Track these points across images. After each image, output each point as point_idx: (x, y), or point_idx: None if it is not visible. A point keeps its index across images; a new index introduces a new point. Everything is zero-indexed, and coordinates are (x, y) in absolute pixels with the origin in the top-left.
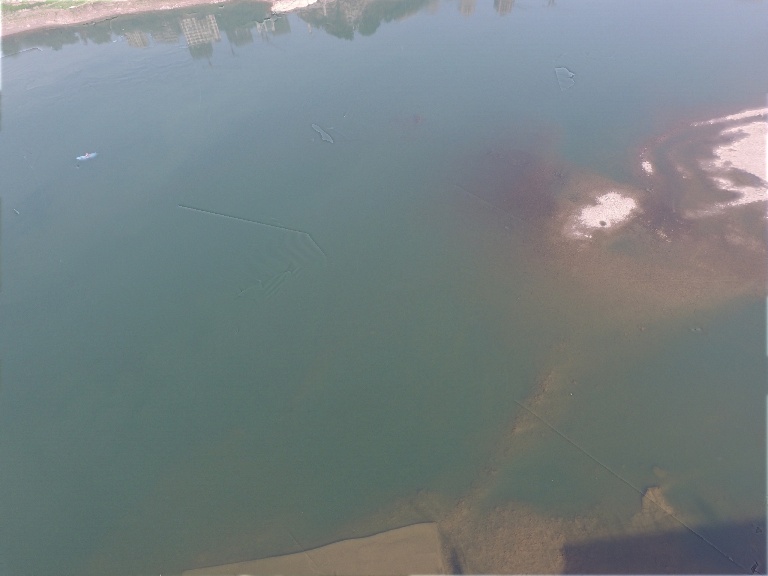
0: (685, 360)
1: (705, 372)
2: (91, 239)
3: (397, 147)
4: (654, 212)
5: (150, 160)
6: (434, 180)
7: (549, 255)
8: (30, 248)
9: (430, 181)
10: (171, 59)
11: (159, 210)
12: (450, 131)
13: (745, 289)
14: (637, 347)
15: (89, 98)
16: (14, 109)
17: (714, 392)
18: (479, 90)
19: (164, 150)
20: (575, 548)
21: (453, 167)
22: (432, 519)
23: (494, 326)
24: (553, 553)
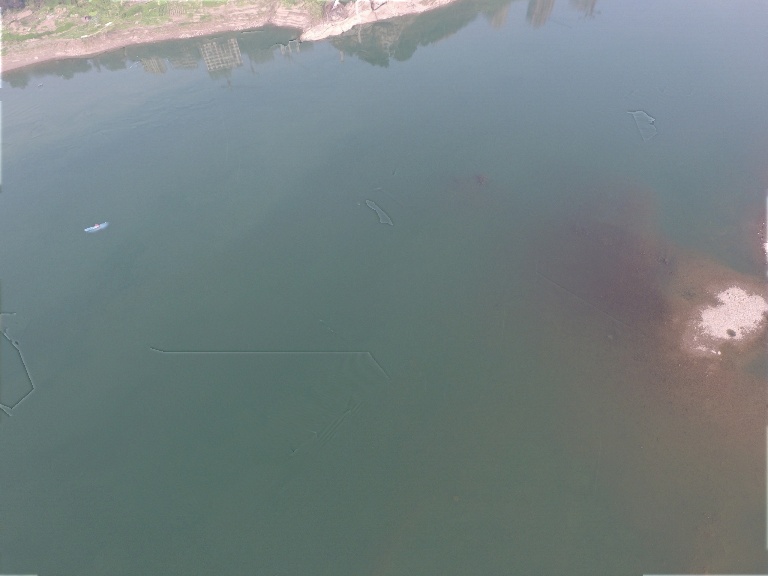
0: None
1: None
2: (100, 419)
3: (460, 217)
4: None
5: (171, 237)
6: (507, 261)
7: (671, 380)
8: None
9: (502, 262)
10: (193, 98)
11: (190, 364)
12: (523, 198)
13: None
14: None
15: (101, 149)
16: (17, 162)
17: None
18: (549, 142)
19: (188, 223)
20: None
21: (531, 246)
22: None
23: (616, 491)
24: None
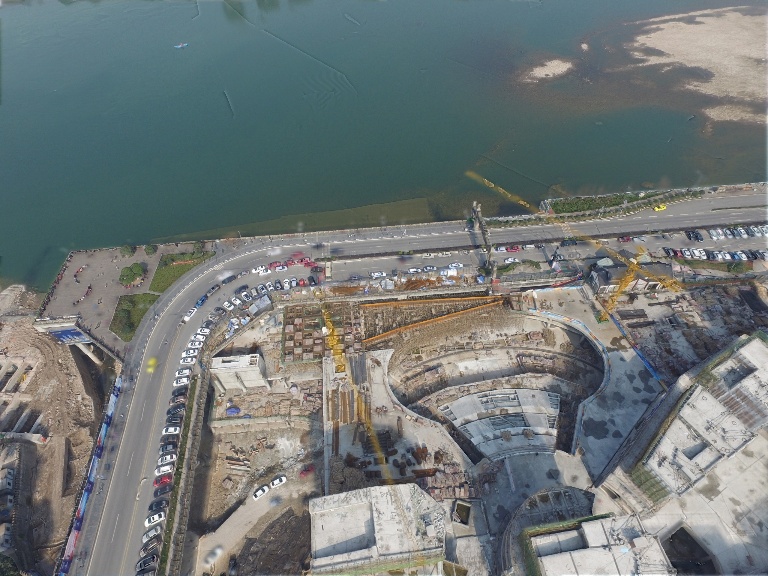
0: (589, 137)
1: (601, 143)
2: (222, 41)
3: (405, 40)
4: (584, 69)
5: None
6: (431, 59)
7: (508, 91)
8: (155, 91)
9: (428, 60)
10: None
11: (258, 33)
12: (444, 28)
13: (636, 105)
14: (559, 131)
15: (174, 15)
16: (119, 23)
17: (605, 152)
18: (467, 6)
19: None
20: (506, 206)
21: (445, 49)
22: (424, 197)
23: (467, 123)
24: (493, 207)
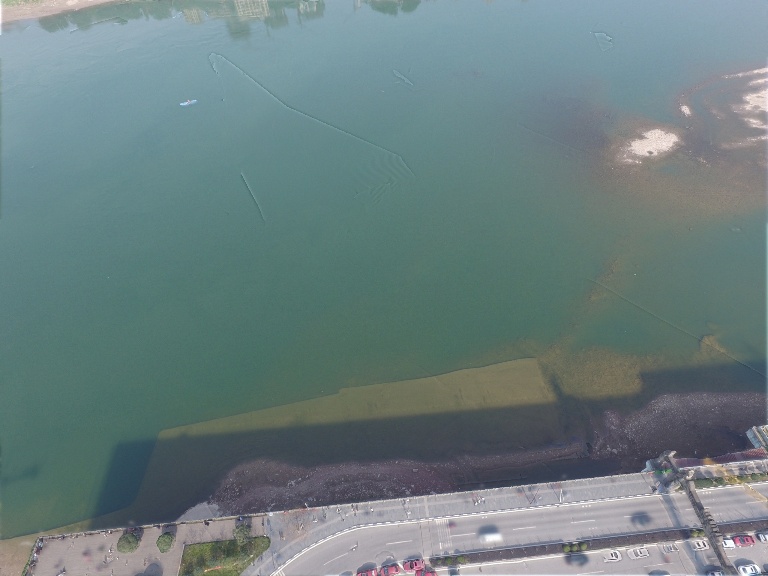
0: (728, 252)
1: (745, 260)
2: (253, 137)
3: (460, 96)
4: (694, 144)
5: None
6: (496, 123)
7: (606, 176)
8: (158, 171)
9: (492, 124)
10: (243, 26)
11: (299, 119)
12: (508, 82)
13: None
14: (687, 242)
15: (177, 58)
16: (112, 67)
17: (753, 275)
18: (529, 50)
19: None
20: (649, 374)
21: (513, 111)
22: (532, 356)
23: (565, 228)
24: (631, 377)
